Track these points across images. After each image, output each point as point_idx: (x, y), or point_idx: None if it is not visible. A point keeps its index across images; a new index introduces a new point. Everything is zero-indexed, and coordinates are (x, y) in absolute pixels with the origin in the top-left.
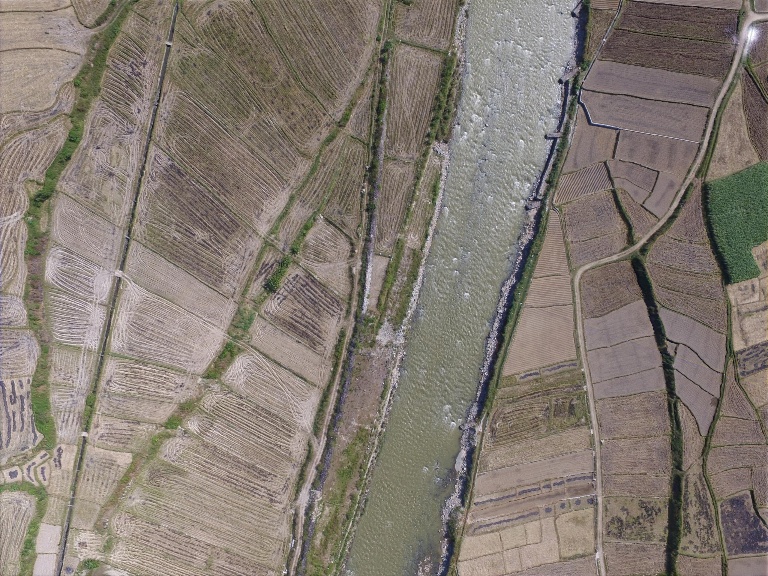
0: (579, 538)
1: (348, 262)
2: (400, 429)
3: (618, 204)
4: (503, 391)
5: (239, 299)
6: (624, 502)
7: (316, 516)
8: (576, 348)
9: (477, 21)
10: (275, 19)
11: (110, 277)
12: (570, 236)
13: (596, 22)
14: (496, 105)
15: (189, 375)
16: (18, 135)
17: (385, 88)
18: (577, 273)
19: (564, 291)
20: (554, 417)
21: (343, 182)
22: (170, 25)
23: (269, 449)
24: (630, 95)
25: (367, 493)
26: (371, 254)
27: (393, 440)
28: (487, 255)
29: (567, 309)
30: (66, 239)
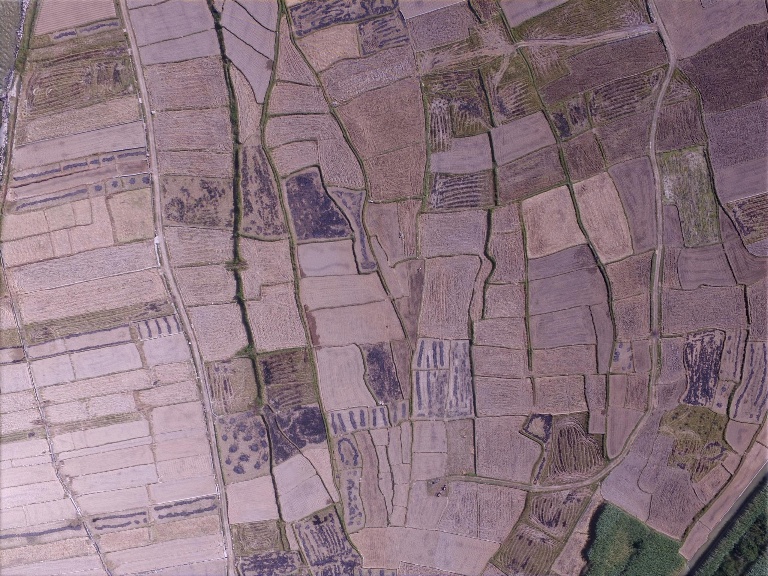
0: (137, 222)
1: None
2: None
3: None
4: (37, 52)
5: None
6: (184, 182)
7: None
8: (114, 4)
9: None
10: None
11: None
12: None
13: None
14: None
15: None
16: None
17: None
18: None
19: None
20: (98, 84)
21: None
22: None
23: None
24: None
25: None
26: None
27: None
28: None
29: None
30: None
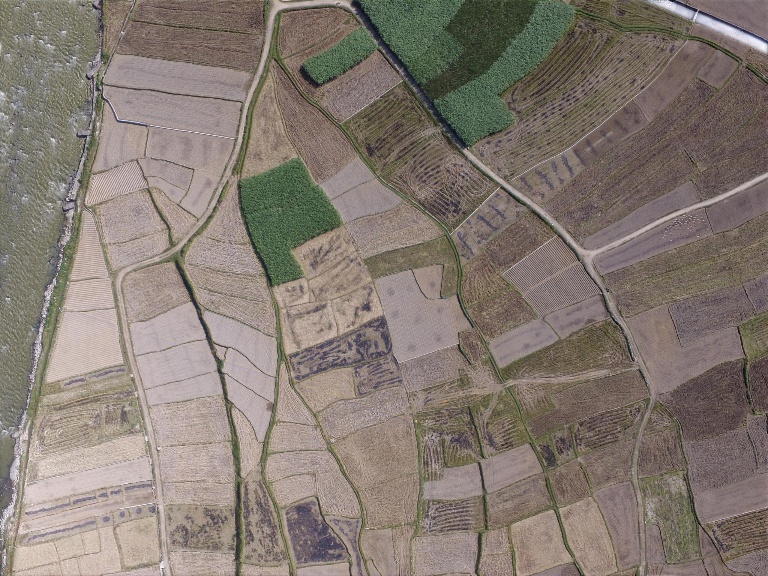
0: (143, 547)
1: None
2: None
3: (155, 204)
4: (48, 398)
5: None
6: (188, 510)
7: None
8: (122, 353)
9: None
10: None
11: None
12: (108, 238)
13: (112, 14)
14: (22, 103)
15: None
16: None
17: None
18: (118, 276)
19: (105, 295)
20: (106, 424)
21: None
22: None
23: None
24: (155, 90)
25: None
26: None
27: None
28: (26, 258)
29: (110, 313)
30: None
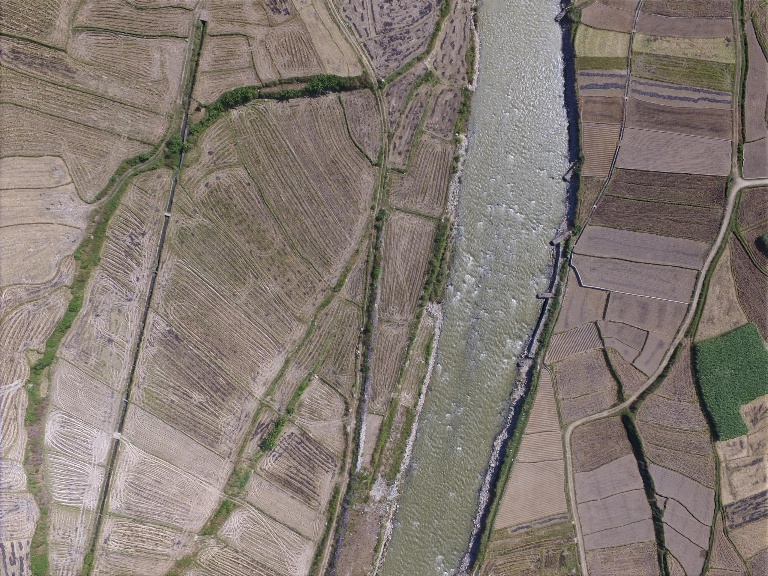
0: None
1: (342, 420)
2: None
3: (608, 363)
4: (495, 544)
5: (235, 459)
6: None
7: None
8: (567, 502)
9: (470, 186)
10: (272, 190)
11: (108, 439)
12: (561, 393)
13: (587, 189)
14: (488, 266)
15: (186, 533)
16: (19, 306)
17: (379, 254)
18: (568, 429)
19: (555, 447)
20: (545, 568)
21: (338, 343)
22: (169, 197)
23: None
24: (620, 259)
25: None
26: (365, 414)
27: None
28: (479, 411)
29: (558, 464)
30: (66, 403)
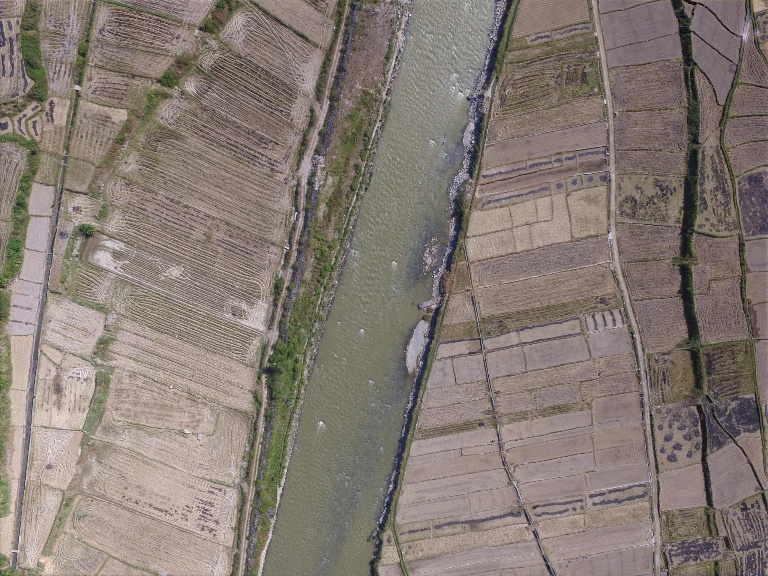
0: (591, 218)
1: None
2: (406, 98)
3: None
4: (513, 55)
5: None
6: (638, 180)
7: (319, 183)
8: (589, 9)
9: None
10: None
11: None
12: None
13: None
14: None
15: (185, 26)
16: None
17: None
18: None
19: None
20: (566, 85)
21: None
22: None
23: (270, 114)
24: None
25: (372, 166)
26: None
27: (398, 109)
28: None
29: None
30: None
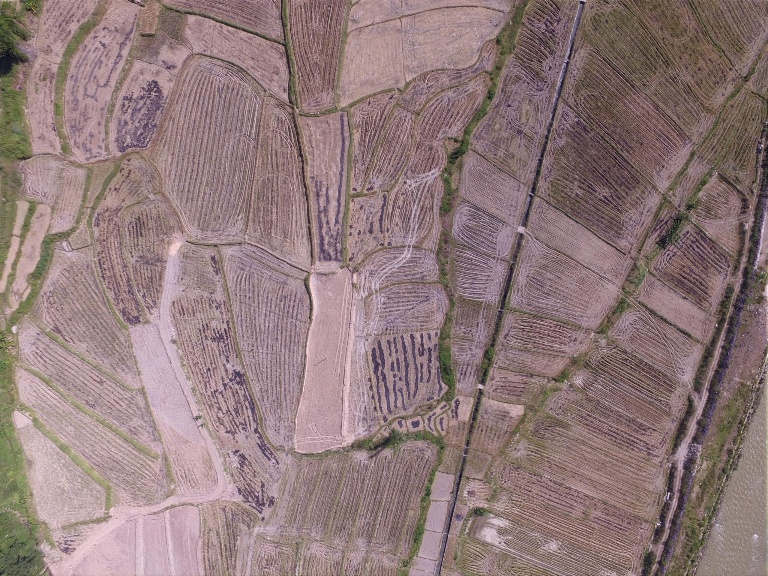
0: None
1: (739, 218)
2: None
3: None
4: None
5: (635, 255)
6: None
7: (697, 469)
8: None
9: None
10: None
11: (513, 233)
12: None
13: None
14: None
15: (583, 330)
16: (440, 93)
17: None
18: None
19: None
20: None
21: (740, 138)
22: None
23: (650, 404)
24: None
25: (741, 448)
26: (766, 210)
27: None
28: None
29: None
30: (473, 196)
